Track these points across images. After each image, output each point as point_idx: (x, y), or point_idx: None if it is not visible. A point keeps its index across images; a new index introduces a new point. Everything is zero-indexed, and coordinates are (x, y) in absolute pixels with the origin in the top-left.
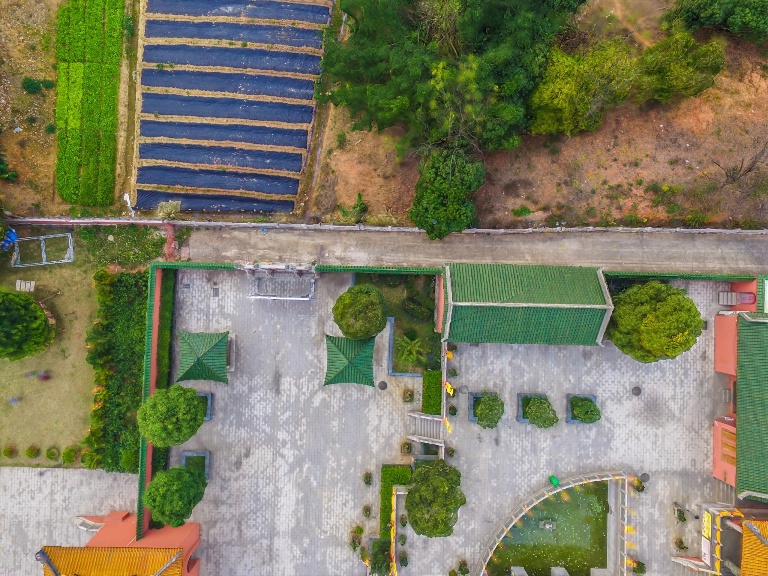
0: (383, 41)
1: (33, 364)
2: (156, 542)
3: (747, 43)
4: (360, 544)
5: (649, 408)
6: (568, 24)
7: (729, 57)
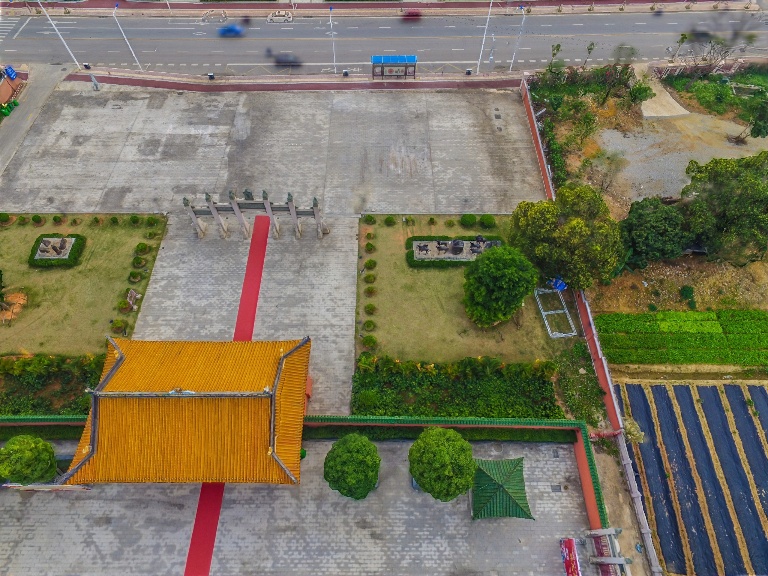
0: None
1: (450, 307)
2: None
3: None
4: None
5: None
6: None
7: None
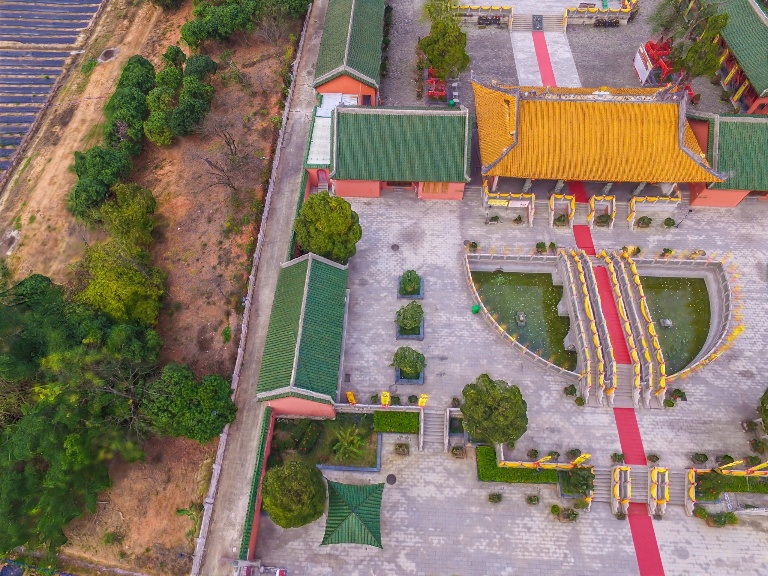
0: (1, 468)
1: None
2: None
3: (134, 177)
4: None
5: (409, 239)
6: (60, 289)
7: None
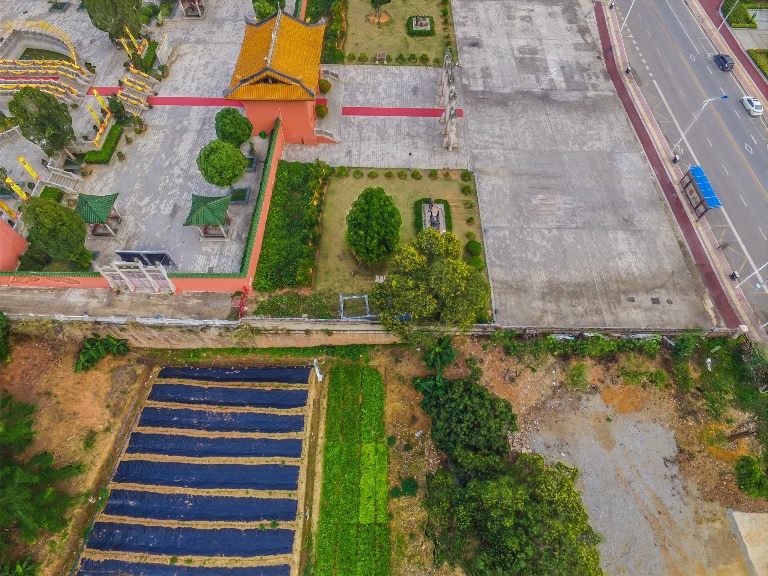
0: None
1: None
2: (265, 117)
3: None
4: None
5: None
6: None
7: None
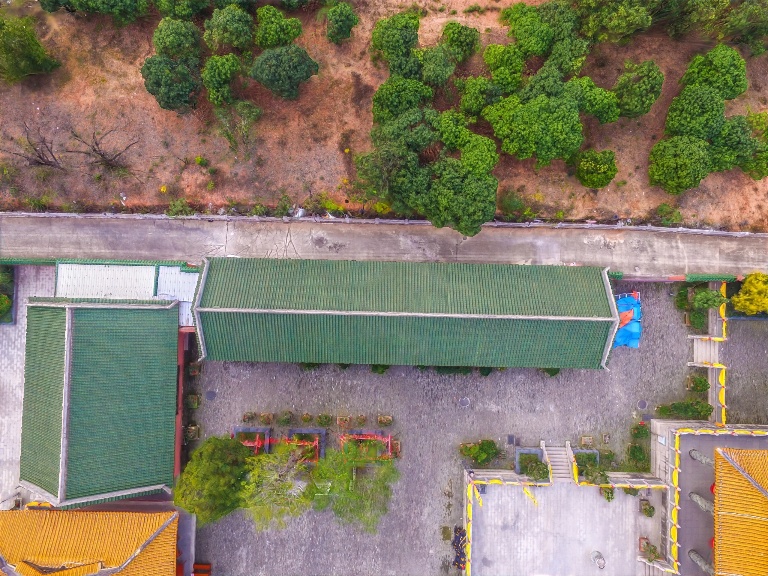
0: None
1: None
2: None
3: (154, 26)
4: None
5: None
6: None
7: (130, 40)
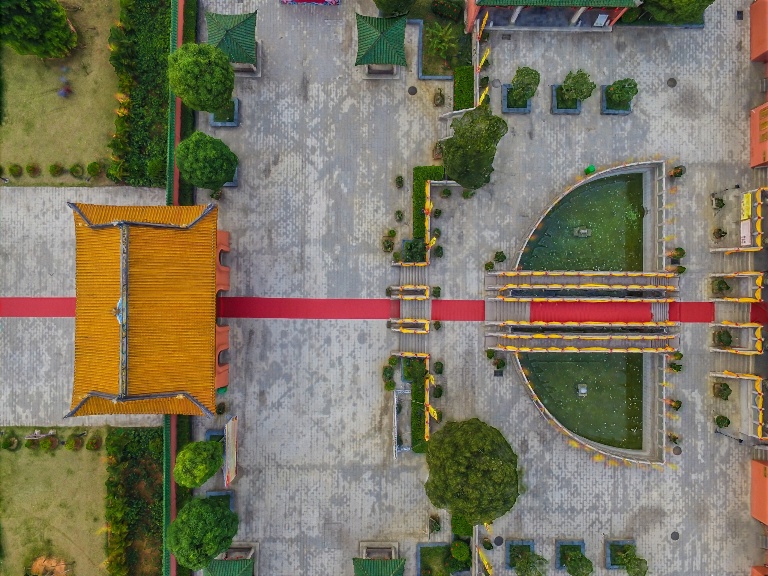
0: None
1: (54, 82)
2: None
3: None
4: (393, 249)
5: (685, 100)
6: None
7: None
